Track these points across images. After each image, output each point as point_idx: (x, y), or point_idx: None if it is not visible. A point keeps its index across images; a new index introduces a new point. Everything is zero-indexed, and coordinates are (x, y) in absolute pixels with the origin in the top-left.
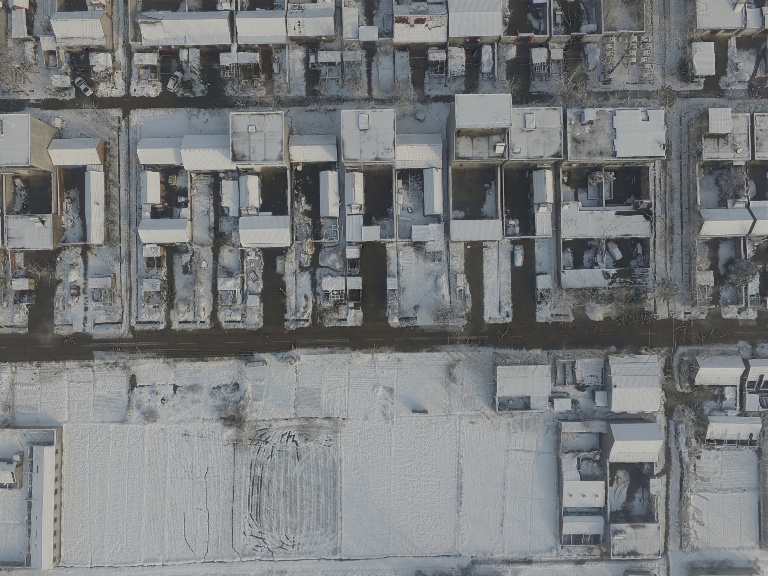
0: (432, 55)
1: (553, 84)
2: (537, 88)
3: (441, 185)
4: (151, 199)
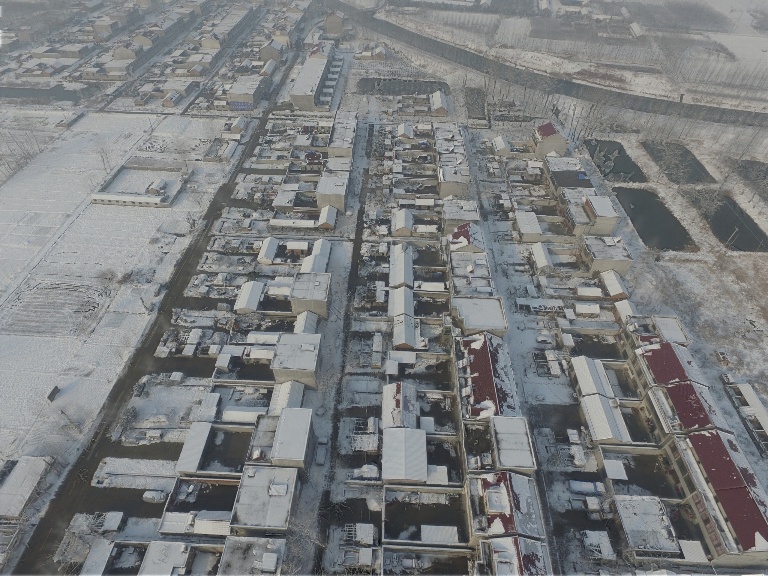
0: (372, 419)
1: (334, 554)
2: (333, 534)
3: (250, 421)
4: (290, 244)
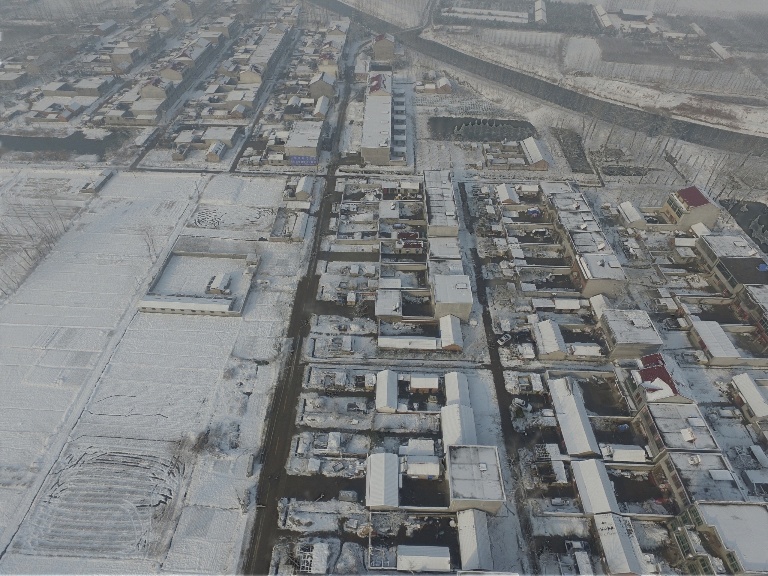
0: None
1: None
2: None
3: None
4: (414, 381)
